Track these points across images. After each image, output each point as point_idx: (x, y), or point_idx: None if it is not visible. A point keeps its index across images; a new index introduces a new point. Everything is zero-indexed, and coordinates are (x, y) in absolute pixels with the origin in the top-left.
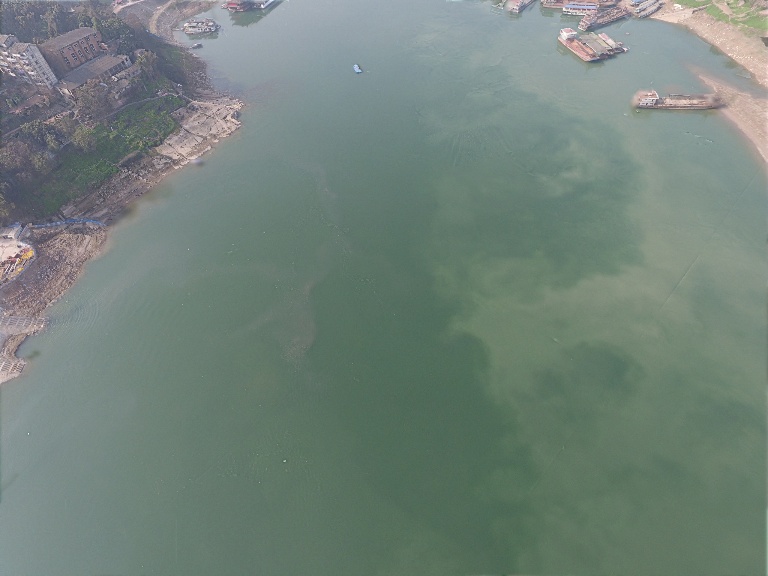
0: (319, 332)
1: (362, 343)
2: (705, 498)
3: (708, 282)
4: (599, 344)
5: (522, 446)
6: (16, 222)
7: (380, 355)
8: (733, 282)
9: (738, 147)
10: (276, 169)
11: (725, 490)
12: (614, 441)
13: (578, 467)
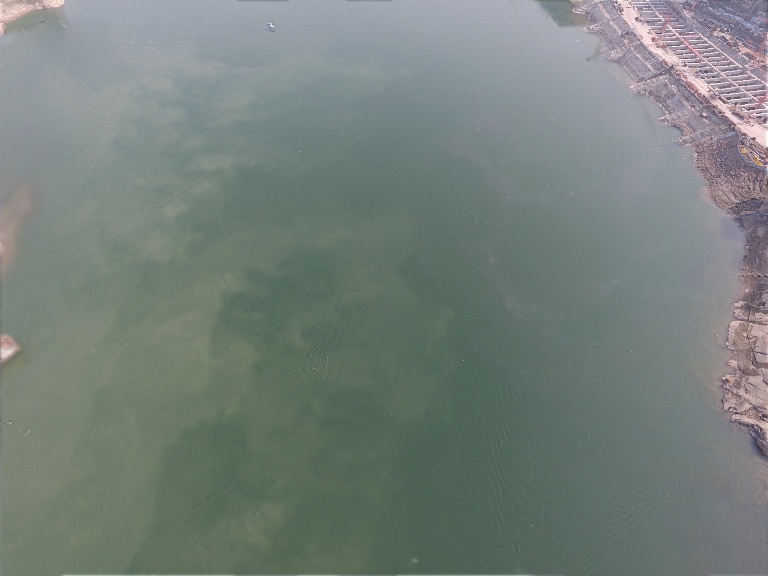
0: None
1: None
2: (261, 102)
3: (165, 189)
4: (273, 152)
5: None
6: None
7: None
8: (147, 190)
9: None
10: (588, 298)
11: (250, 105)
12: None
13: None
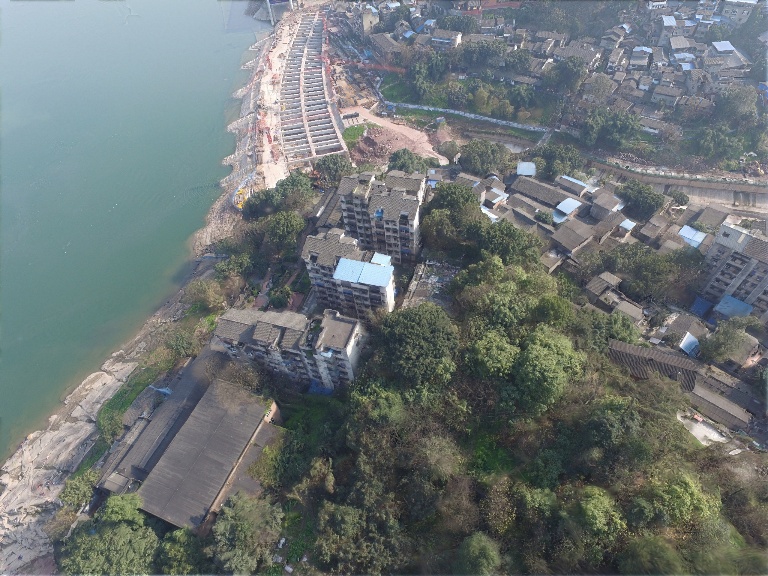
0: None
1: None
2: None
3: None
4: None
5: None
6: None
7: None
8: None
9: None
10: None
11: None
12: None
13: None
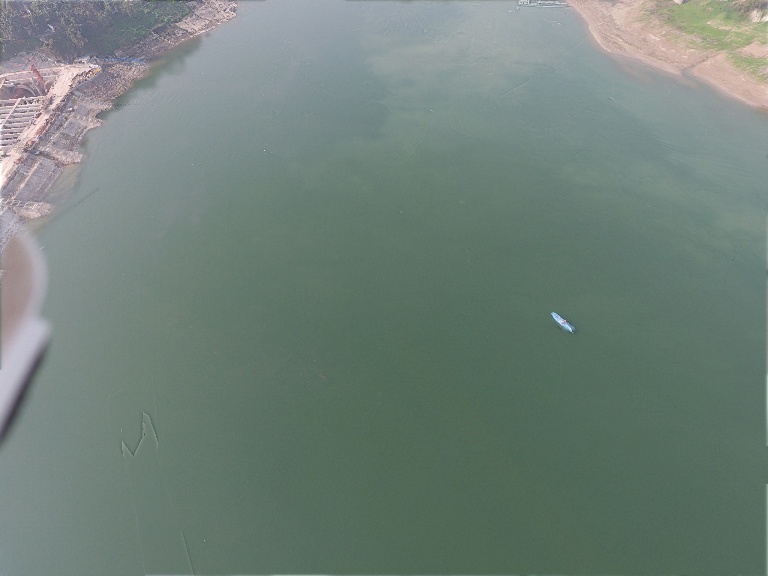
0: (287, 106)
1: (314, 113)
2: (495, 163)
3: (532, 88)
4: None
5: (399, 143)
6: (86, 54)
7: (324, 117)
8: (547, 88)
9: (578, 27)
10: (262, 37)
11: (507, 161)
12: (452, 144)
13: (429, 152)
